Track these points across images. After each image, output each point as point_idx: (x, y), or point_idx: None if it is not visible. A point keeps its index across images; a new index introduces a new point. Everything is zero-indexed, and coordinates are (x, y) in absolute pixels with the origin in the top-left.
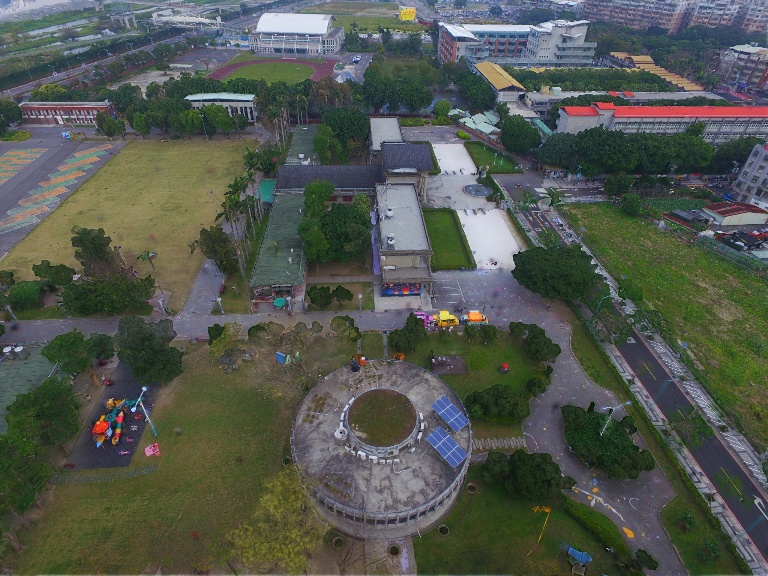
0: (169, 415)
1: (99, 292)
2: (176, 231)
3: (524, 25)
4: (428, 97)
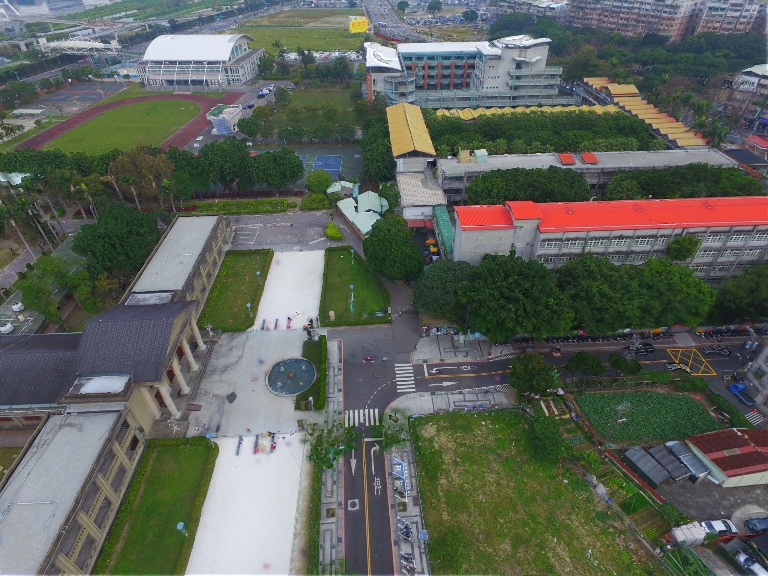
0: None
1: None
2: None
3: (477, 42)
4: (292, 169)
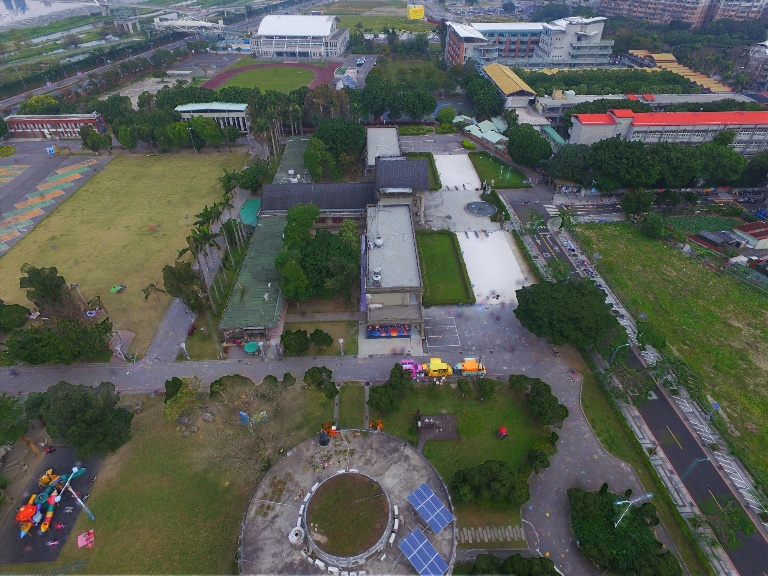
0: (112, 492)
1: (45, 341)
2: (150, 259)
3: (536, 23)
4: (431, 104)
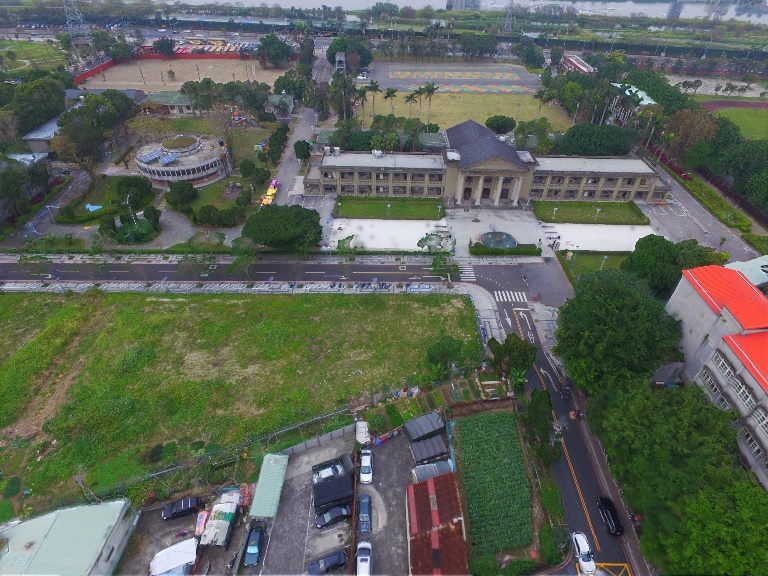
0: None
1: None
2: None
3: None
4: None
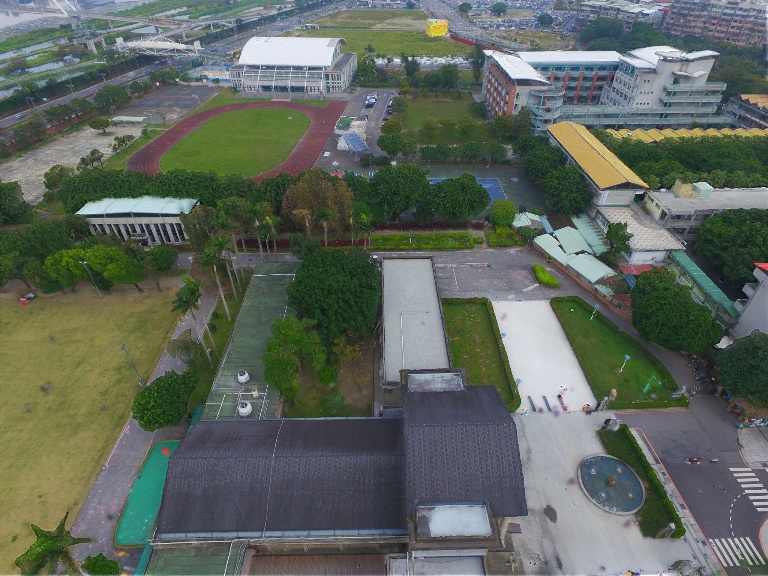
0: None
1: None
2: None
3: (603, 51)
4: (481, 200)
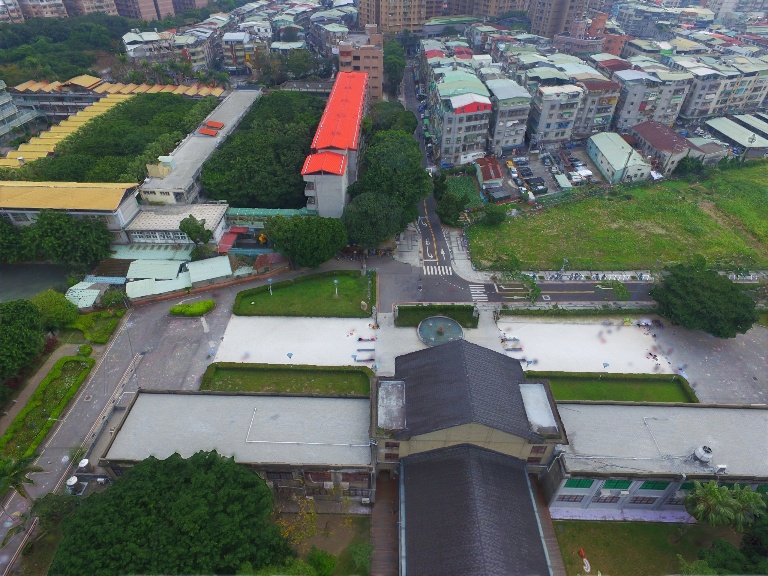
0: None
1: None
2: None
3: None
4: (33, 313)
